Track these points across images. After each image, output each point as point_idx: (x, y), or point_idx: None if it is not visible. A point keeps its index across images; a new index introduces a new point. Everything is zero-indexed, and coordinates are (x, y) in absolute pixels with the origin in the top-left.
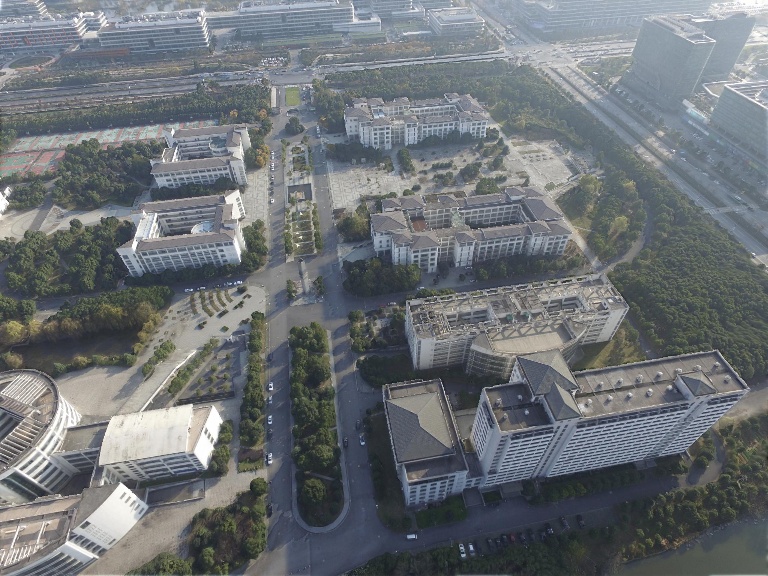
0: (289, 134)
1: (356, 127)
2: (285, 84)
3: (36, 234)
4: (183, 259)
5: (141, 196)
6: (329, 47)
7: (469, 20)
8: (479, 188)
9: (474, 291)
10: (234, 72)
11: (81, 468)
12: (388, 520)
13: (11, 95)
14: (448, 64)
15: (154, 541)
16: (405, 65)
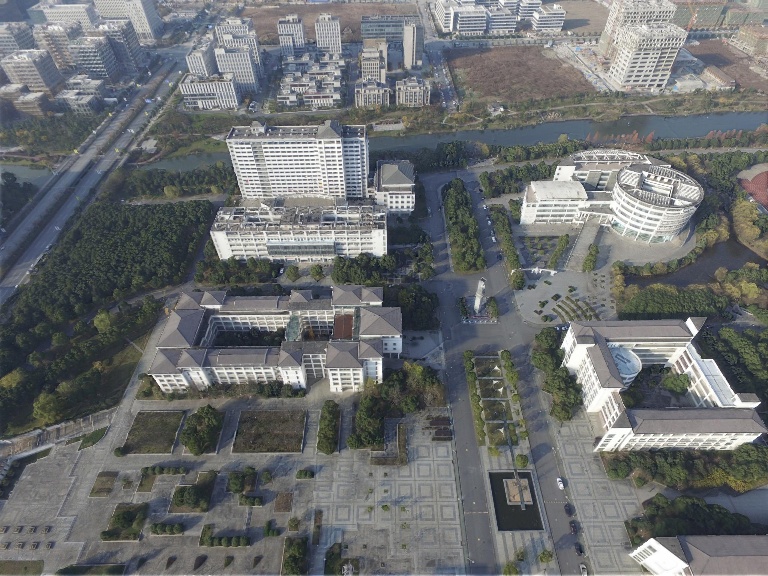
0: None
1: None
2: None
3: None
4: None
5: None
6: None
7: None
8: (213, 431)
9: (328, 230)
10: None
11: None
12: (419, 182)
13: None
14: None
15: None
16: None
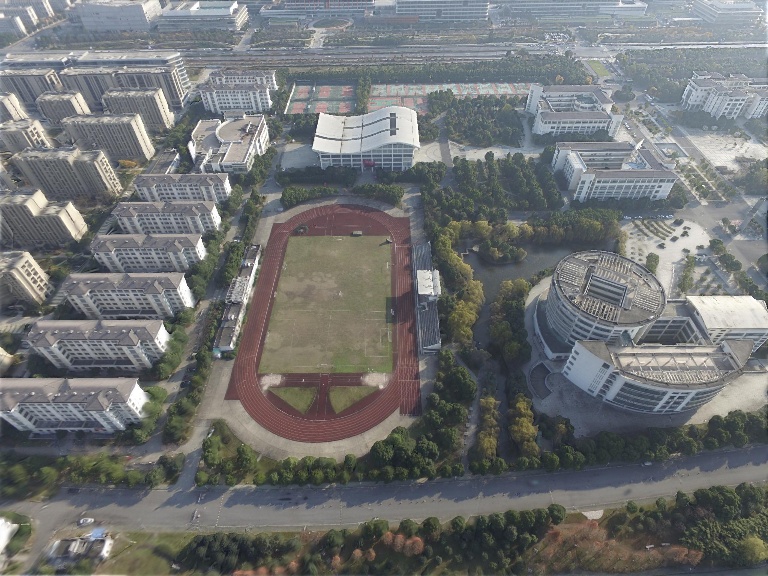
0: (621, 100)
1: (702, 97)
2: (583, 57)
3: (468, 160)
4: (624, 190)
5: (522, 140)
6: (603, 27)
7: (747, 9)
8: None
9: None
10: (525, 43)
11: (648, 336)
12: None
13: (335, 50)
14: (748, 49)
15: (747, 396)
16: (693, 48)
